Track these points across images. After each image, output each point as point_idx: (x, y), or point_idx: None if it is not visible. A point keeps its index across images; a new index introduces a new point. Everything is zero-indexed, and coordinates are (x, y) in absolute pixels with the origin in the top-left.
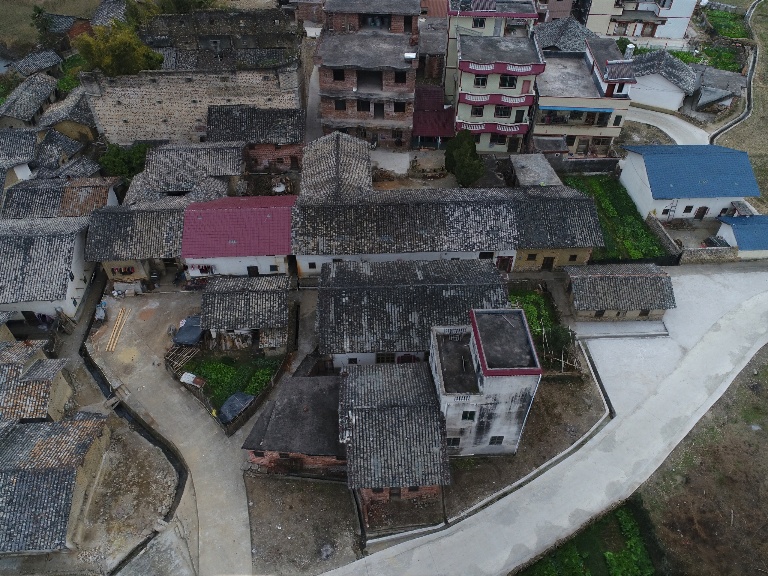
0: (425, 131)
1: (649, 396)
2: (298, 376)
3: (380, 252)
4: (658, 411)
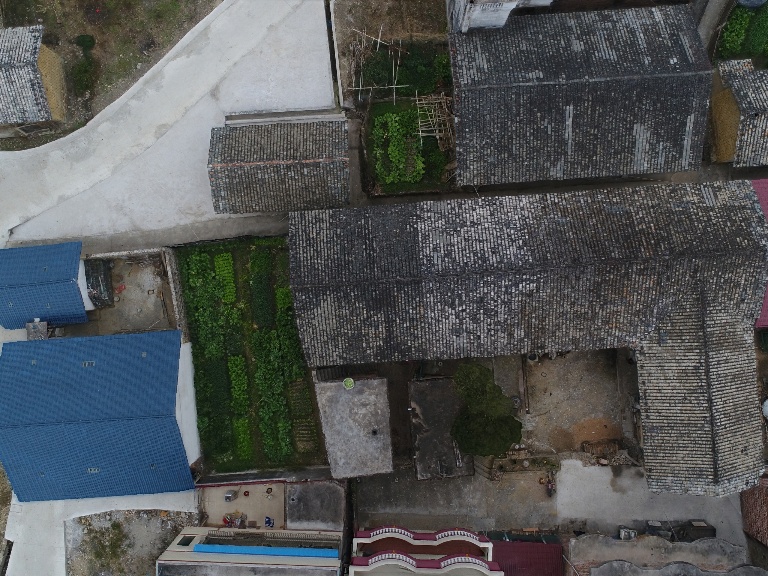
0: (539, 553)
1: (279, 23)
2: (702, 1)
3: (621, 189)
4: (275, 3)
